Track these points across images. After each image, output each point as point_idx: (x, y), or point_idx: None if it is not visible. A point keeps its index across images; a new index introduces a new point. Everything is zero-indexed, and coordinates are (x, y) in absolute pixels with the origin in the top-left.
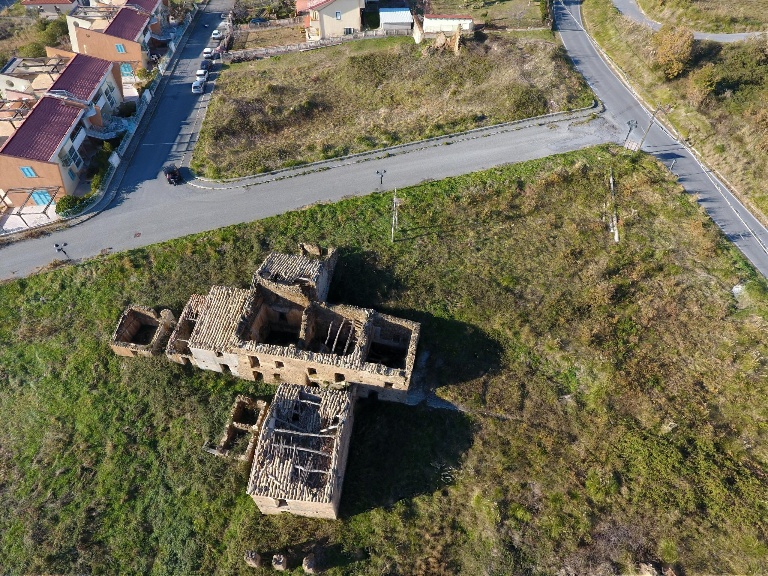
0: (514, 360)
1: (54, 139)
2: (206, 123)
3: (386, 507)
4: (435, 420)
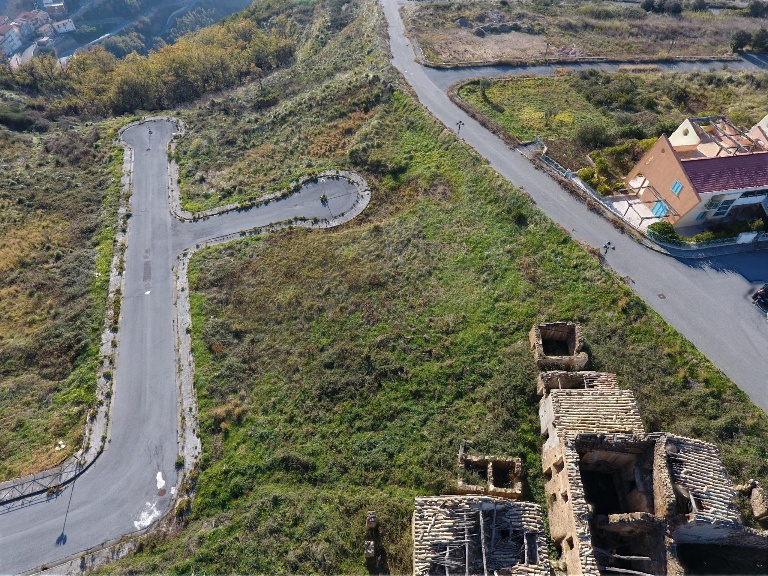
0: None
1: (729, 184)
2: None
3: None
4: None
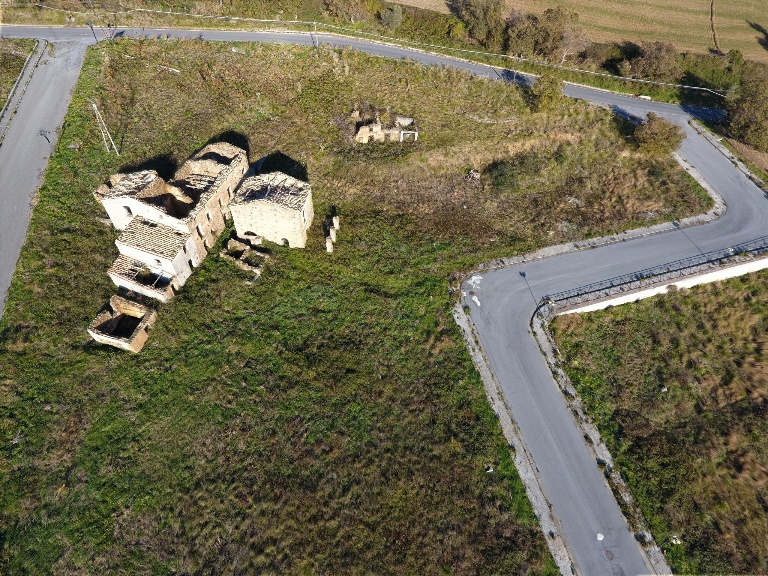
0: (243, 131)
1: None
2: None
3: (312, 196)
4: (268, 169)
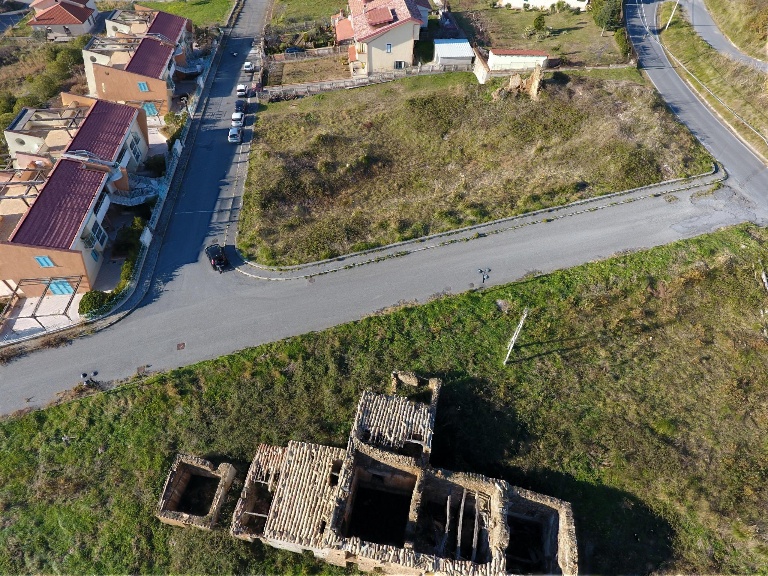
0: (689, 547)
1: (75, 217)
2: (249, 184)
3: None
4: None
